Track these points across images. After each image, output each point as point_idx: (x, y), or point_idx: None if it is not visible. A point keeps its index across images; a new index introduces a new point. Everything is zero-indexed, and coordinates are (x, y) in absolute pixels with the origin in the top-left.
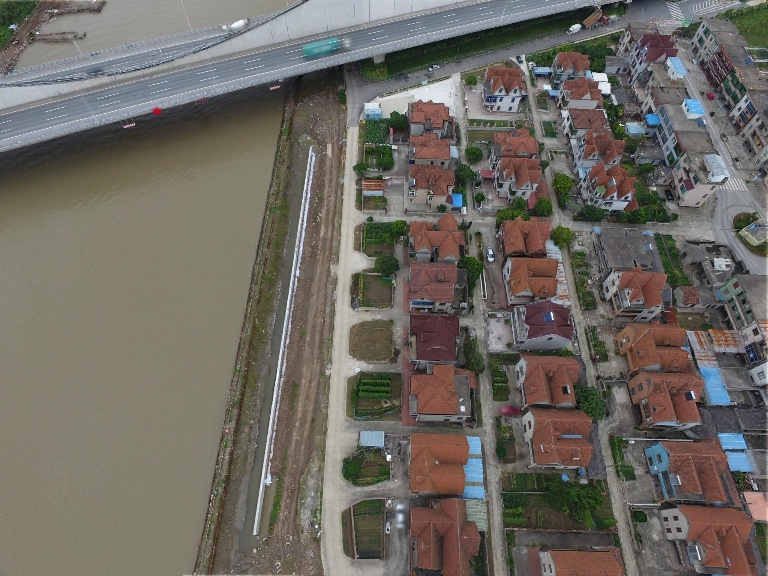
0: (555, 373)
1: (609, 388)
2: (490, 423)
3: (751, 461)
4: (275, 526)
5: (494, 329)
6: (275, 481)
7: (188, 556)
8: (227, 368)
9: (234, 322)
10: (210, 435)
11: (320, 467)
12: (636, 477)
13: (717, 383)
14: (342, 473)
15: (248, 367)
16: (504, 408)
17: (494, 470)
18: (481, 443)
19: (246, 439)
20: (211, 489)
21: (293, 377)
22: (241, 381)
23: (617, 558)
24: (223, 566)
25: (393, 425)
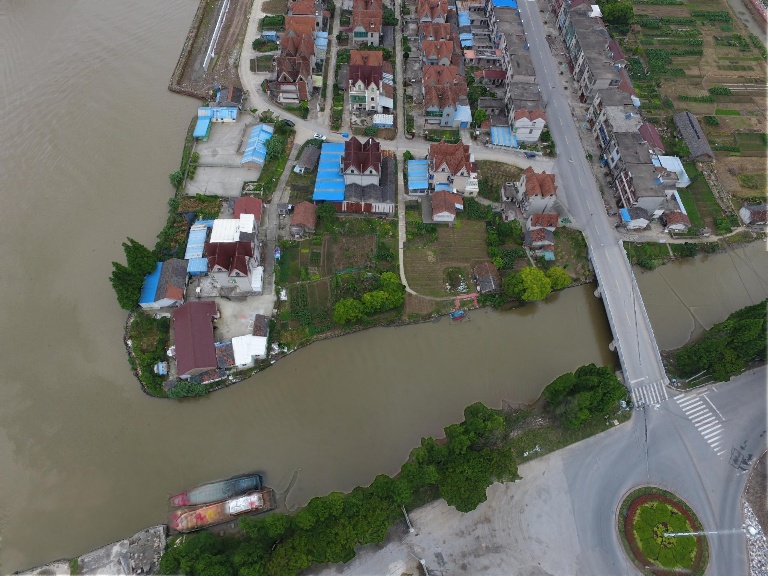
0: (369, 1)
1: (406, 22)
2: (337, 34)
3: (472, 41)
4: (215, 67)
5: (347, 3)
6: (216, 56)
7: (169, 73)
8: (191, 17)
9: (195, 2)
10: (181, 38)
11: (240, 45)
12: (411, 51)
13: (465, 18)
14: (252, 48)
15: (203, 17)
16: (345, 29)
17: (335, 48)
18: (330, 39)
19: (201, 42)
20: (181, 53)
21: (229, 23)
22: (199, 20)
23: (390, 67)
24: (187, 79)
25: (283, 34)
